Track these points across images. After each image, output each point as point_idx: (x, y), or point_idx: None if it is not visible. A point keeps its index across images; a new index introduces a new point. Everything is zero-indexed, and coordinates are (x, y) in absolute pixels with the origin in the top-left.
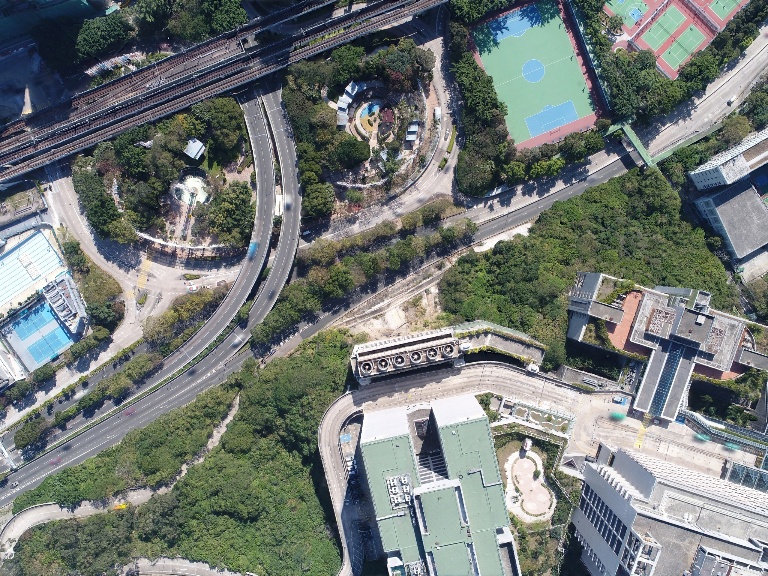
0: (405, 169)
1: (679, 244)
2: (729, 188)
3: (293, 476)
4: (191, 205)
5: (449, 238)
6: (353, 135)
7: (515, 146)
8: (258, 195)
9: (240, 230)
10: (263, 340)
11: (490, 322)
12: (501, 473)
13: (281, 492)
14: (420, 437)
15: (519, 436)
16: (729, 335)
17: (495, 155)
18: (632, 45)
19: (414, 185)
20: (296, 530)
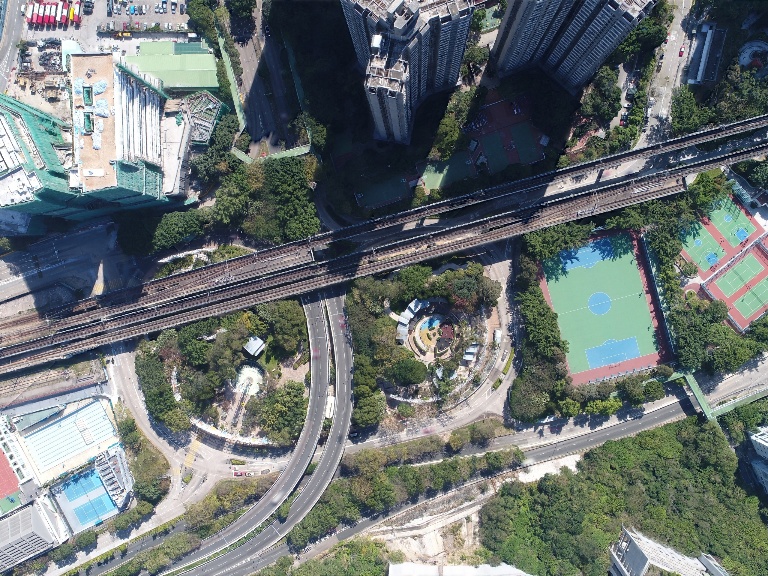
0: None
1: (731, 509)
2: None
3: None
4: (245, 394)
5: (495, 465)
6: (411, 346)
7: (572, 377)
8: (311, 395)
9: (290, 429)
10: (300, 544)
11: None
12: None
13: None
14: None
15: None
16: None
17: (551, 389)
18: (704, 289)
19: (466, 401)
20: None
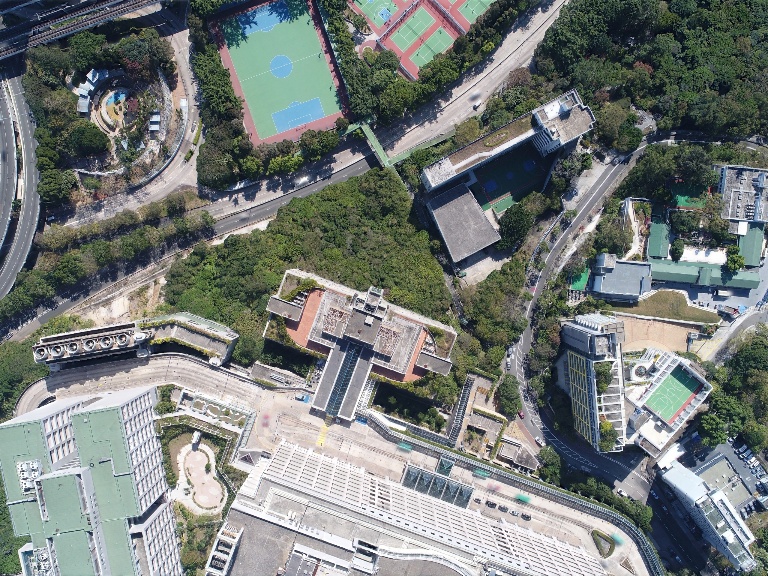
0: (151, 159)
1: (403, 246)
2: (446, 192)
3: None
4: None
5: (184, 230)
6: (99, 123)
7: (259, 141)
8: None
9: None
10: None
11: (192, 314)
12: (173, 465)
13: None
14: None
15: (189, 428)
16: (407, 337)
17: (231, 149)
18: (380, 45)
19: (160, 175)
20: None
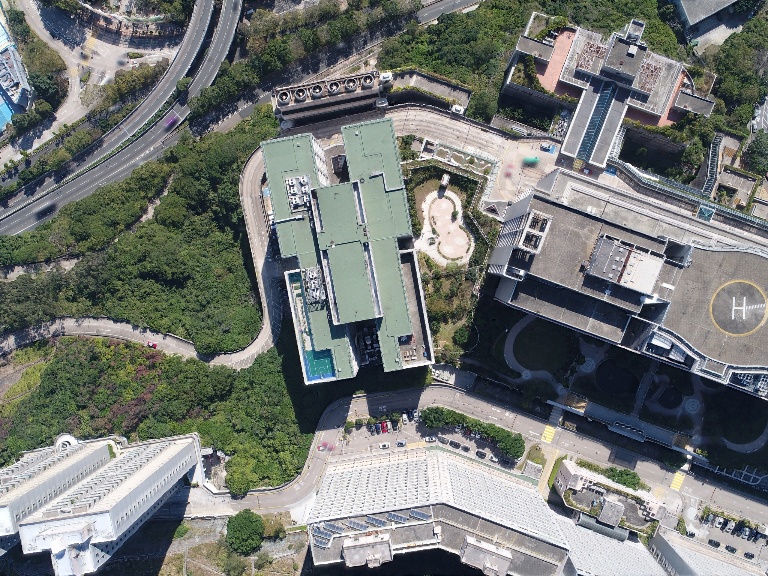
0: None
1: (630, 15)
2: None
3: (224, 251)
4: None
5: (392, 13)
6: None
7: None
8: None
9: (182, 2)
10: (198, 110)
11: None
12: (418, 213)
13: (210, 263)
14: (337, 174)
15: (437, 172)
16: (666, 76)
17: None
18: None
19: None
20: (221, 298)
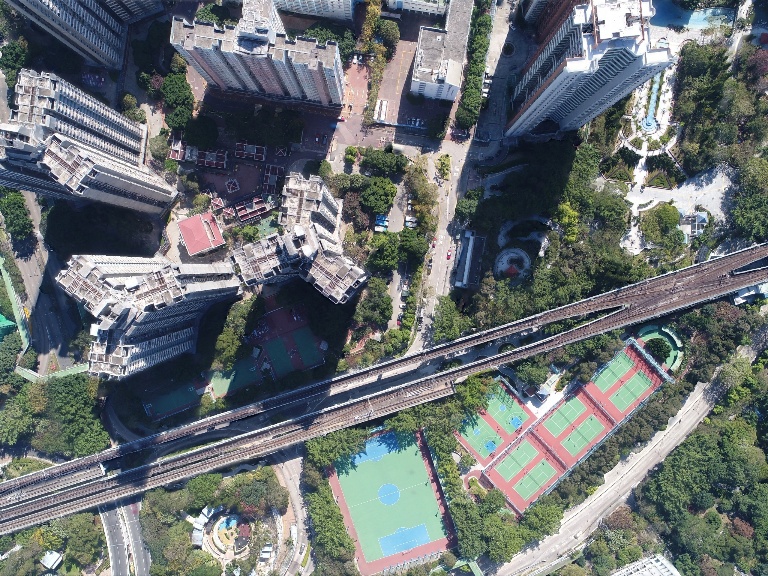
0: None
1: None
2: None
3: None
4: None
5: None
6: (210, 546)
7: None
8: None
9: None
10: None
11: None
12: None
13: None
14: None
15: None
16: None
17: None
18: None
19: None
20: None
